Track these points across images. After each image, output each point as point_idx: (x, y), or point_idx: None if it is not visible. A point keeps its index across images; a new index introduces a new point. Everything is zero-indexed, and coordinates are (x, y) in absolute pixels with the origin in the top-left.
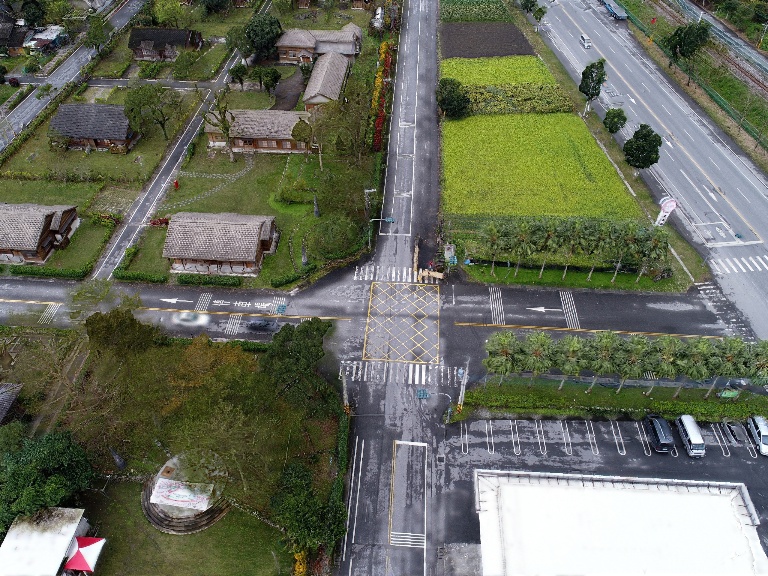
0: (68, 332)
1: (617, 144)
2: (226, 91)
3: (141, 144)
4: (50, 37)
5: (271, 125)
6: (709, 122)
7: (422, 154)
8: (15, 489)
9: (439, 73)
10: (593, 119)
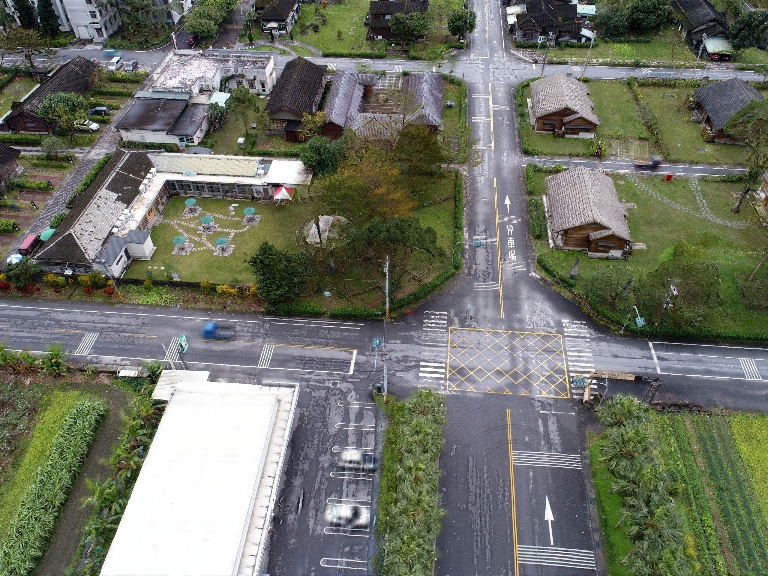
0: None
1: None
2: None
3: (729, 147)
4: None
5: None
6: None
7: None
8: None
9: None
10: None
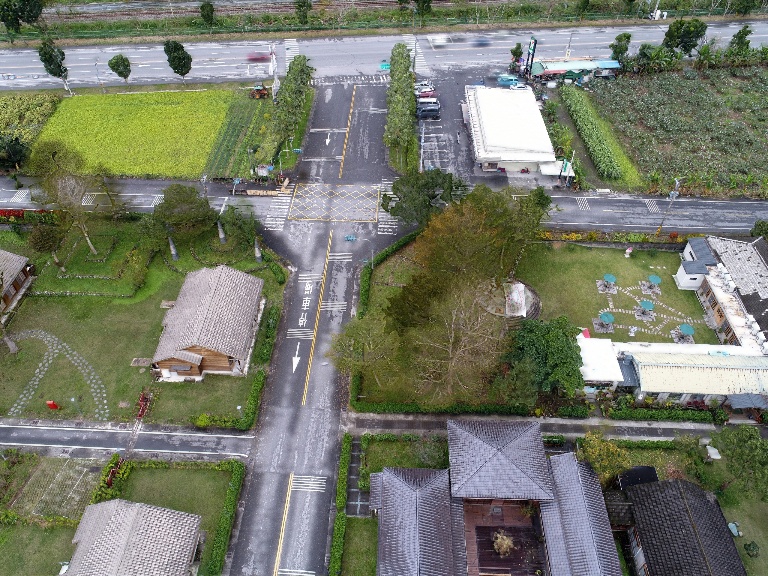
0: (348, 439)
1: (130, 86)
2: None
3: None
4: None
5: None
6: (119, 46)
7: None
8: None
9: None
10: (81, 91)
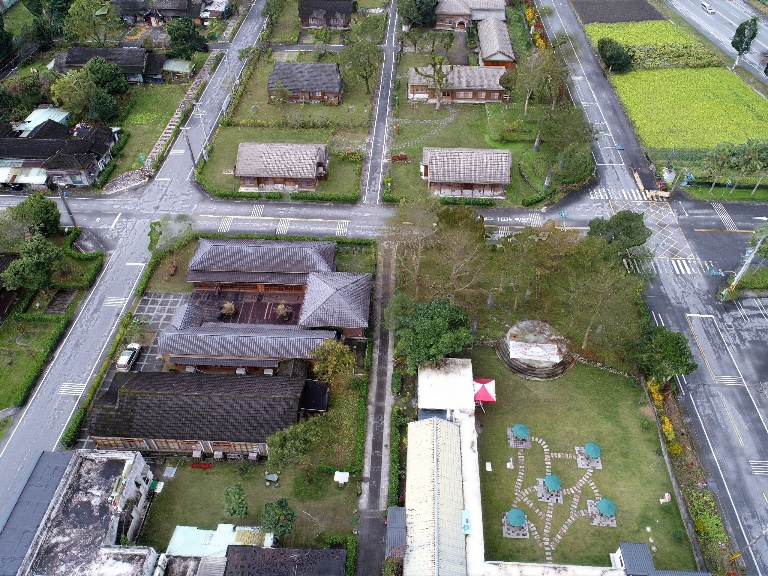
0: (371, 240)
1: None
2: (401, 53)
3: (347, 97)
4: (220, 9)
5: (469, 77)
6: None
7: (604, 102)
8: (433, 336)
9: (587, 36)
10: (742, 72)
